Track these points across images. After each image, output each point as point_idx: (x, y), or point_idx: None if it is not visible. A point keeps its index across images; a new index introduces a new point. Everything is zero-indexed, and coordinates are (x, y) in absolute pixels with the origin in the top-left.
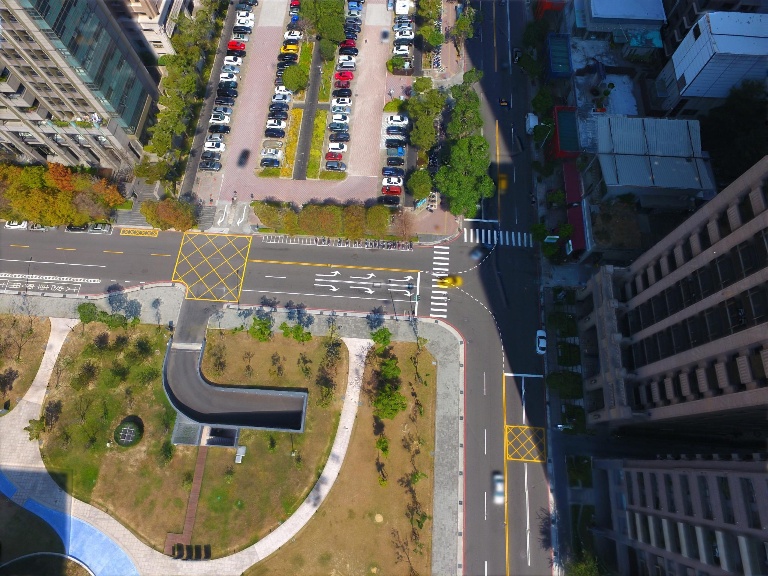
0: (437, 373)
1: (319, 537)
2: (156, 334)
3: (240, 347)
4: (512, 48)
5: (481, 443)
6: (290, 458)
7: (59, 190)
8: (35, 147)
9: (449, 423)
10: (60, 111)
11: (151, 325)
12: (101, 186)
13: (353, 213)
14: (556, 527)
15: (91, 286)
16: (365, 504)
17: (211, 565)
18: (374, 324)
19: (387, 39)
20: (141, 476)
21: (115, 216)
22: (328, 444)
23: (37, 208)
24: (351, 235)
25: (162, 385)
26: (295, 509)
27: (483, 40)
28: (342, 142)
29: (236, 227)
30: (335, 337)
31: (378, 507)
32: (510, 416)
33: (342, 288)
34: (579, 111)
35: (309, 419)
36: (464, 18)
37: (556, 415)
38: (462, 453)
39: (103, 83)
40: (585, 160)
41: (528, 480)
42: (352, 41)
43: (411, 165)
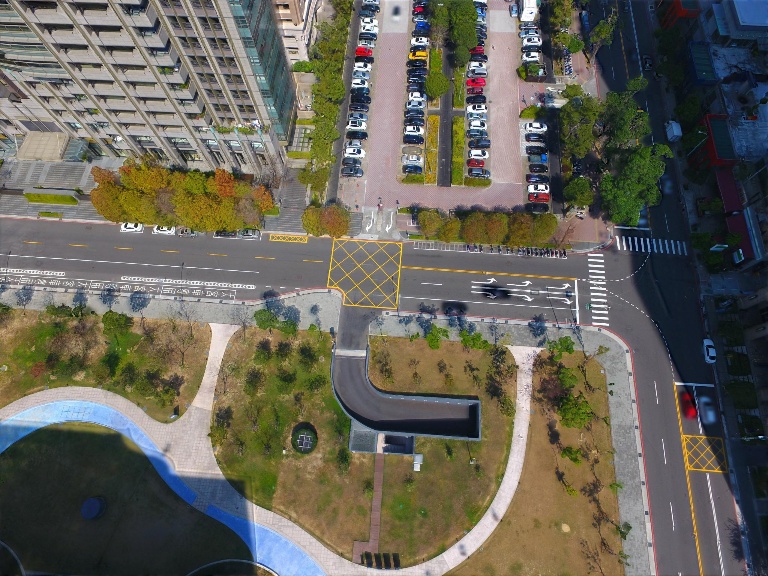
0: (607, 382)
1: (507, 546)
2: (318, 340)
3: (404, 354)
4: (641, 55)
5: (660, 453)
6: (469, 466)
7: (218, 196)
8: (180, 153)
9: (625, 432)
10: (222, 117)
11: (312, 331)
12: (261, 192)
13: (522, 221)
14: (746, 538)
15: (247, 292)
16: (550, 513)
17: (402, 574)
18: (537, 332)
19: (514, 46)
20: (320, 483)
21: (262, 222)
22: (505, 452)
23: (199, 214)
24: (516, 243)
25: (330, 392)
26: (479, 518)
27: (611, 47)
28: (482, 149)
29: (385, 233)
30: (499, 345)
31: (563, 517)
32: (686, 426)
33: (500, 295)
34: (731, 119)
35: (483, 427)
36: (607, 25)
37: (733, 425)
38: (642, 463)
39: (274, 90)
40: (745, 168)
41: (712, 491)
42: (481, 48)
43: (555, 172)
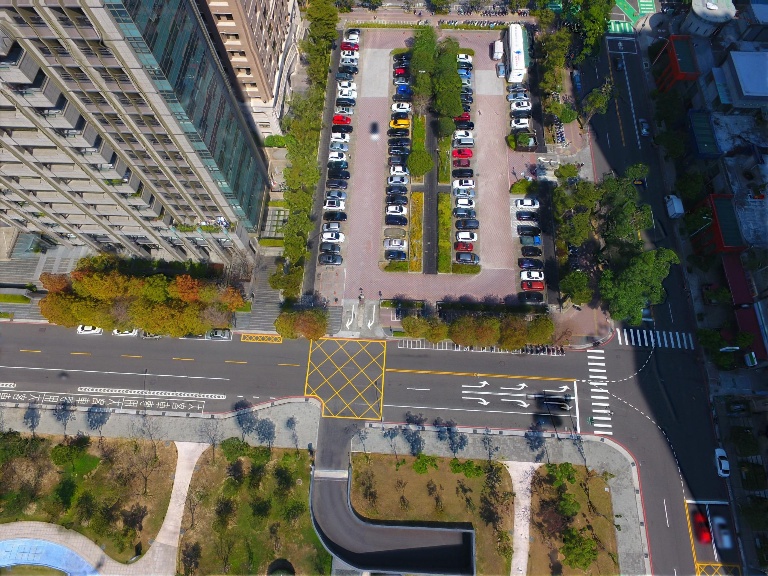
0: (612, 502)
1: None
2: (295, 460)
3: (390, 474)
4: (637, 119)
5: None
6: None
7: (181, 300)
8: (142, 244)
9: (634, 562)
10: (183, 215)
11: (288, 449)
12: (229, 296)
13: (515, 327)
14: None
15: (216, 403)
16: None
17: None
18: (535, 444)
19: (502, 110)
20: None
21: (233, 319)
22: None
23: (161, 323)
24: (510, 348)
25: (309, 521)
26: None
27: None
28: (470, 230)
29: (367, 330)
30: (494, 460)
31: None
32: (700, 552)
33: (493, 401)
34: (736, 198)
35: (478, 560)
36: (600, 95)
37: (750, 550)
38: None
39: (238, 189)
40: (754, 257)
41: None
42: (467, 114)
43: (549, 255)
